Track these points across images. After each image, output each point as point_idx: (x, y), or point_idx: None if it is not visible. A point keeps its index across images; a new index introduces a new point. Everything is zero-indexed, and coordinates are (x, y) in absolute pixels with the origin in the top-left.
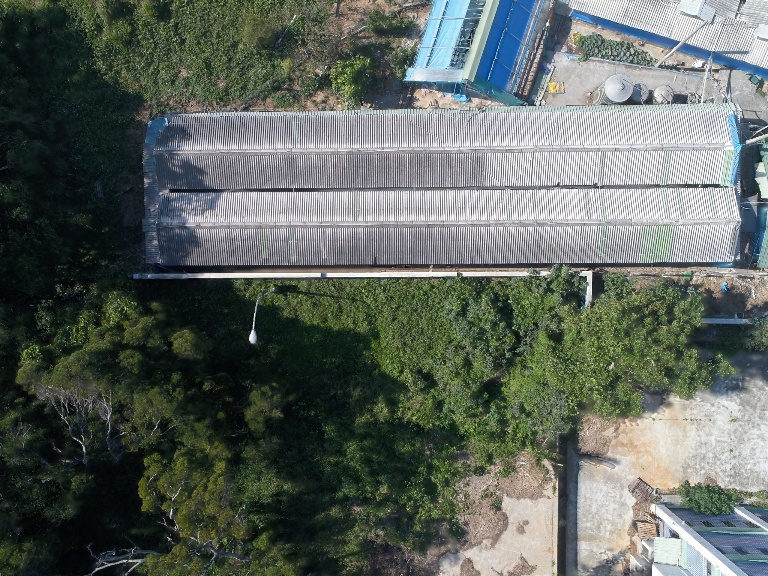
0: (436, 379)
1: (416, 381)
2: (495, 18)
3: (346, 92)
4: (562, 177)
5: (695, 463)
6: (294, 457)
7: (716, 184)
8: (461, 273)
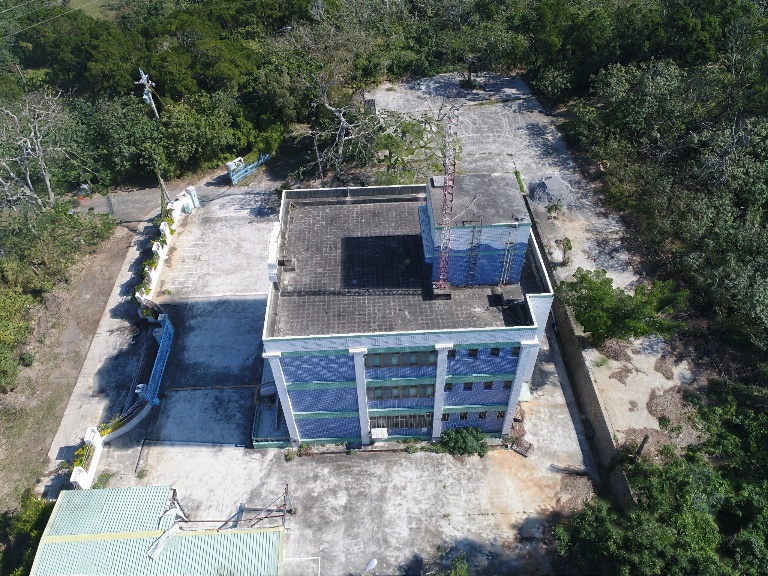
0: None
1: None
2: None
3: None
4: None
5: (477, 474)
6: None
7: None
8: None
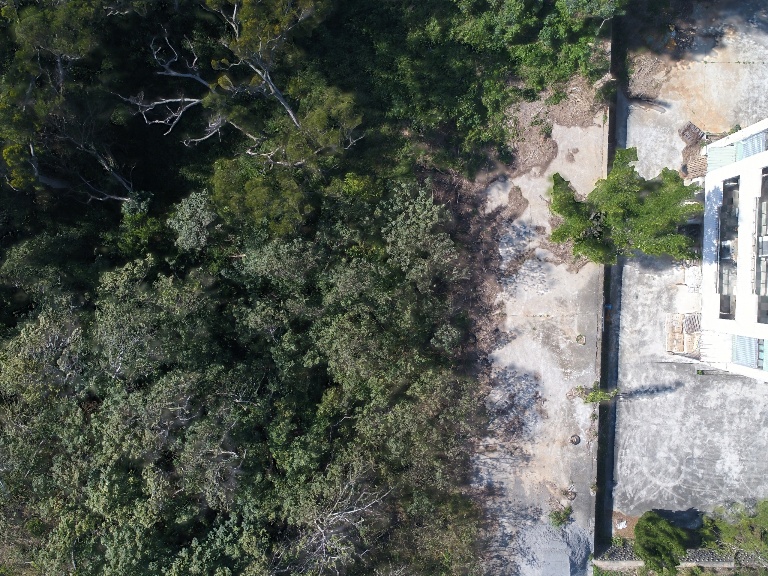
0: (489, 0)
1: None
2: None
3: None
4: None
5: (747, 107)
6: (345, 69)
7: None
8: None
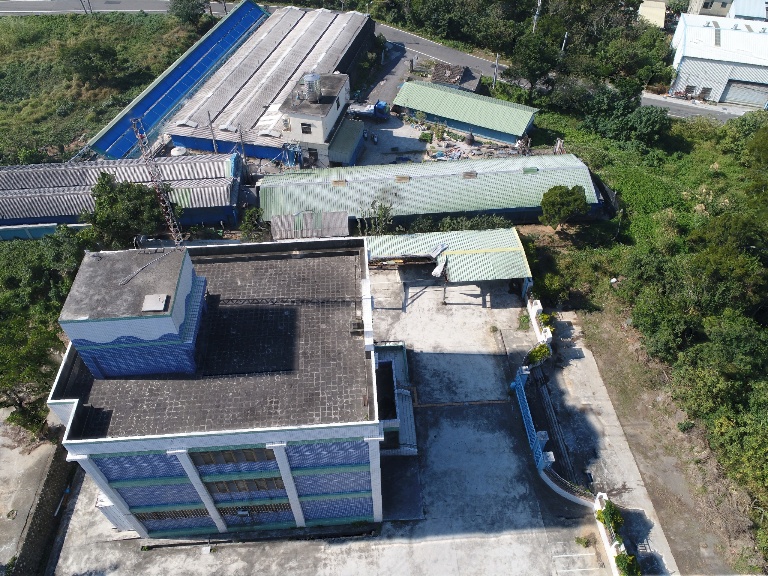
0: None
1: (5, 276)
2: (114, 129)
3: (21, 156)
4: (133, 178)
5: None
6: None
7: (223, 177)
8: (61, 225)
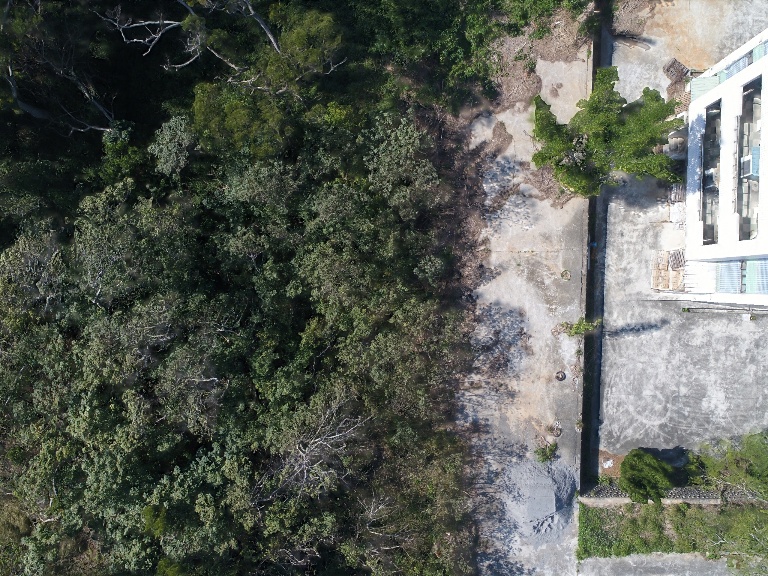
0: None
1: None
2: None
3: None
4: None
5: (731, 43)
6: (328, 2)
7: None
8: None
